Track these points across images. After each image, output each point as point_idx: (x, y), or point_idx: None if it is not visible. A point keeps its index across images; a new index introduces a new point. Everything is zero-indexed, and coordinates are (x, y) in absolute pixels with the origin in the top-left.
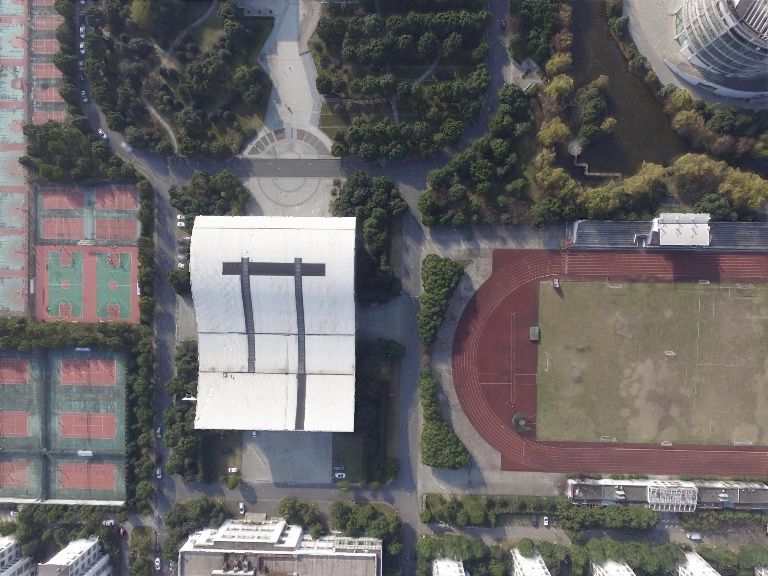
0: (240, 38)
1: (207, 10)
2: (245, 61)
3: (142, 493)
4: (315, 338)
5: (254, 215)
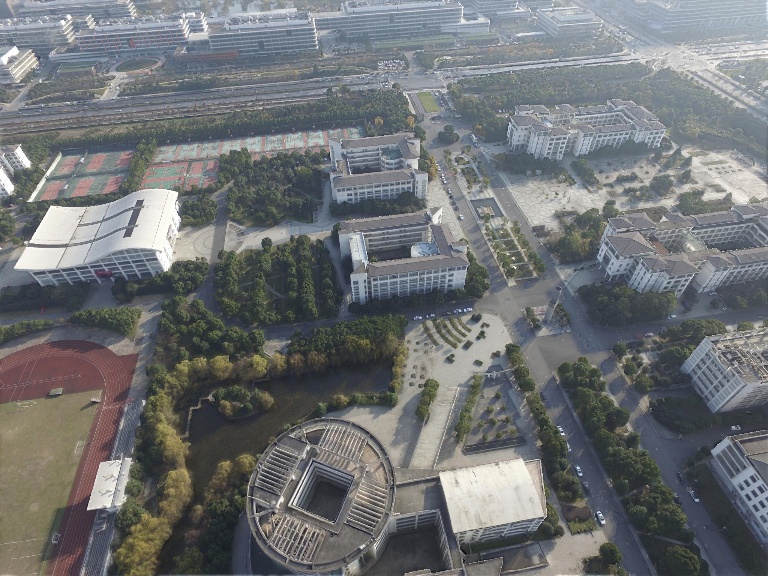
0: (294, 207)
1: (315, 199)
2: (286, 215)
3: (29, 205)
4: (89, 247)
5: (191, 231)
